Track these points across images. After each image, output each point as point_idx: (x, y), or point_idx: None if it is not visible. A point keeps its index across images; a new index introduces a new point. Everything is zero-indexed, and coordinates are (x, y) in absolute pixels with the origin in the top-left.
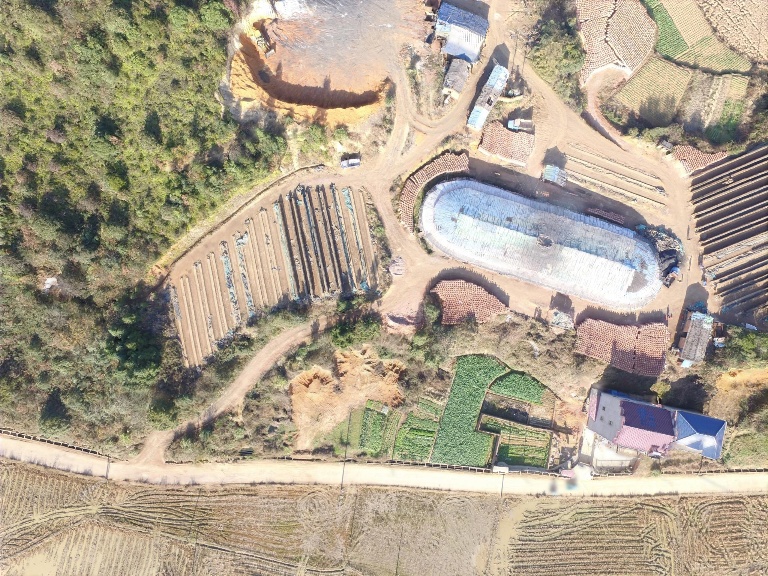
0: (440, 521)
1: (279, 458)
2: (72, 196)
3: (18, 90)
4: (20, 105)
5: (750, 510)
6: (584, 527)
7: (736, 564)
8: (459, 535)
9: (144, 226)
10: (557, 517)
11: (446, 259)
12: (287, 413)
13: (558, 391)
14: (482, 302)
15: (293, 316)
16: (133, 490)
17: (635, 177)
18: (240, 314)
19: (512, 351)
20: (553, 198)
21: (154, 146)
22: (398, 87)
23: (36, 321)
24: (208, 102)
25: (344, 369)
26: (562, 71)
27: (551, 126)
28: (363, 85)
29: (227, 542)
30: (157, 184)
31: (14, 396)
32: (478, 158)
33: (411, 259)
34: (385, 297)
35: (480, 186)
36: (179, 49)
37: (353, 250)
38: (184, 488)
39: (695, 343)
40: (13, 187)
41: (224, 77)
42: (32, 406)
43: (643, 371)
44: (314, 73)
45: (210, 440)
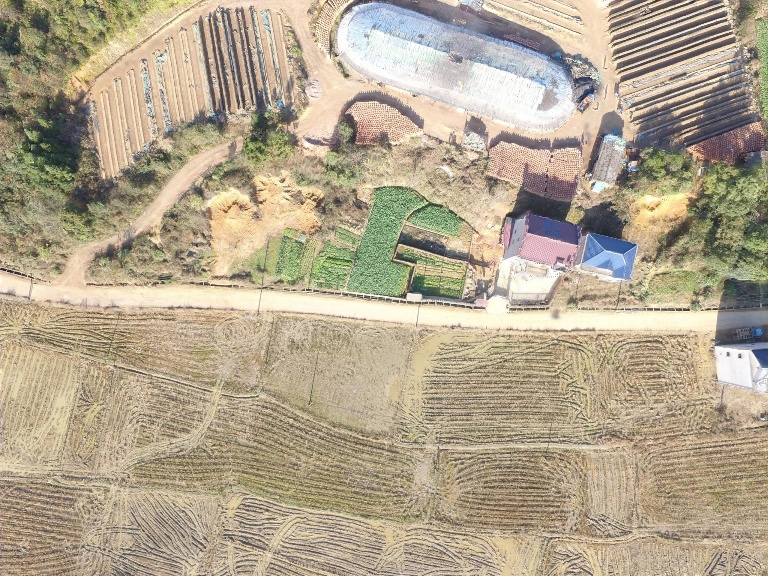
0: (355, 351)
1: (197, 283)
2: None
3: None
4: None
5: (669, 350)
6: (499, 361)
7: (653, 403)
8: (374, 365)
9: (63, 33)
10: (472, 350)
11: (362, 83)
12: (206, 238)
13: (475, 223)
14: (395, 123)
15: (206, 127)
16: (55, 312)
17: (552, 7)
18: (157, 128)
19: (428, 179)
20: (470, 26)
21: None
22: None
23: None
24: None
25: (263, 197)
26: None
27: None
28: None
29: (144, 365)
30: None
31: None
32: None
33: (327, 82)
34: (301, 119)
35: (395, 8)
36: None
37: (269, 70)
38: (104, 310)
39: (606, 164)
40: None
41: None
42: None
43: (555, 194)
44: None
45: (128, 259)
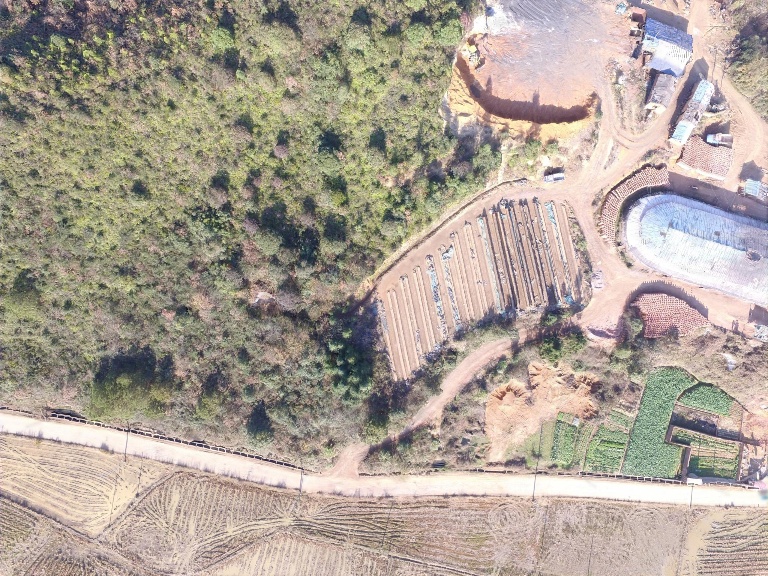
0: (629, 532)
1: (471, 470)
2: (288, 211)
3: (248, 106)
4: (248, 121)
5: None
6: None
7: None
8: (648, 546)
9: (361, 241)
10: (744, 528)
11: (646, 272)
12: (480, 425)
13: (747, 403)
14: (684, 315)
15: (504, 330)
16: (325, 502)
17: None
18: (447, 328)
19: (705, 364)
20: (750, 212)
21: (382, 162)
22: (603, 102)
23: (245, 335)
24: (432, 118)
25: (535, 381)
26: (763, 86)
27: (748, 140)
28: (571, 100)
29: (419, 554)
30: (377, 199)
31: (220, 410)
32: (675, 172)
33: (611, 272)
34: (585, 310)
35: (683, 200)
36: (411, 65)
37: (557, 264)
38: (378, 500)
39: None
40: (236, 202)
41: (446, 92)
42: (237, 419)
43: None
44: (523, 88)
45: (408, 453)
